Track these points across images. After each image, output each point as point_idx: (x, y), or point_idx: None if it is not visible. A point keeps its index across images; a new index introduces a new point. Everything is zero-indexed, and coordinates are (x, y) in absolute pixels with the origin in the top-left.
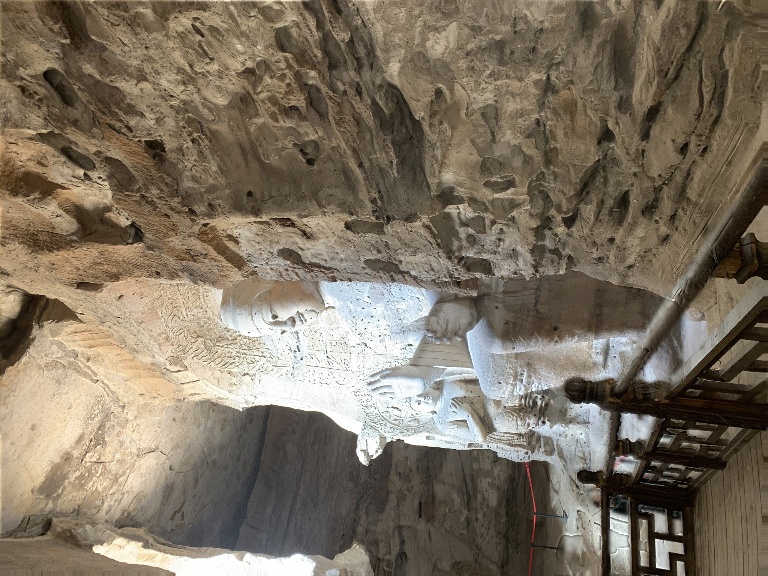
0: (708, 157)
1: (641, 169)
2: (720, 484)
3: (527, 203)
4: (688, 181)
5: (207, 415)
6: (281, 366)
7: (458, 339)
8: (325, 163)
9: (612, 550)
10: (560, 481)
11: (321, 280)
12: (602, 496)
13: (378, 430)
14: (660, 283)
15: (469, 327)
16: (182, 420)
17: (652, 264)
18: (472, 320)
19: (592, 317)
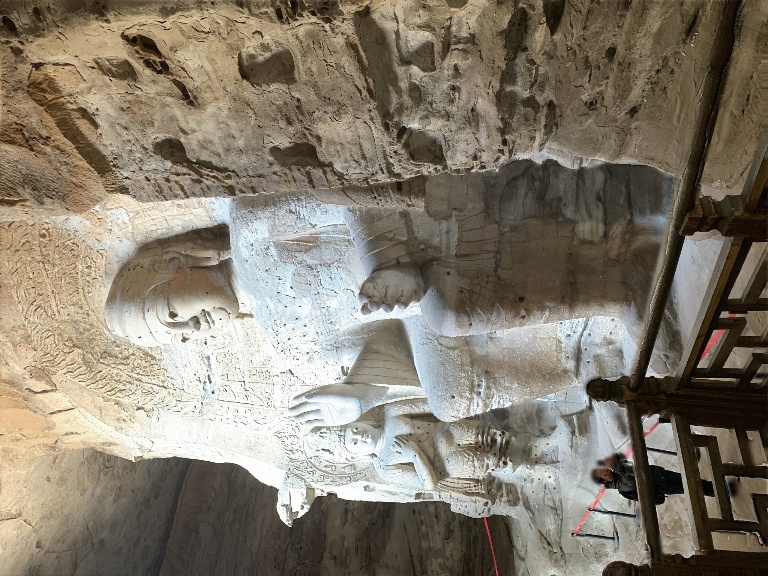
0: None
1: None
2: None
3: None
4: None
5: (96, 479)
6: (187, 401)
7: (400, 307)
8: None
9: (657, 499)
10: (527, 542)
11: (215, 195)
12: (630, 416)
13: (305, 479)
14: (674, 137)
15: (414, 295)
16: (60, 481)
17: (666, 95)
18: (418, 289)
19: (565, 286)
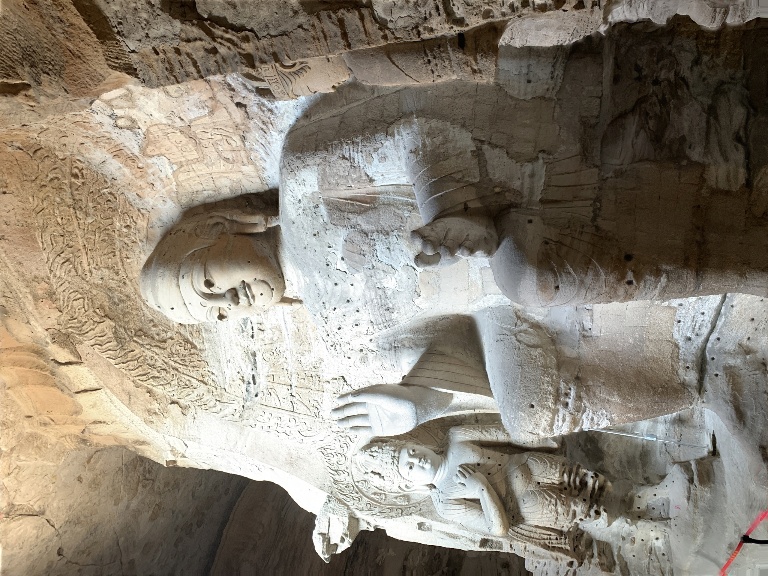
0: None
1: None
2: None
3: None
4: None
5: (133, 490)
6: (227, 402)
7: (464, 252)
8: None
9: None
10: None
11: (232, 71)
12: None
13: (348, 505)
14: None
15: (483, 242)
16: (92, 484)
17: None
18: (489, 238)
19: (690, 245)
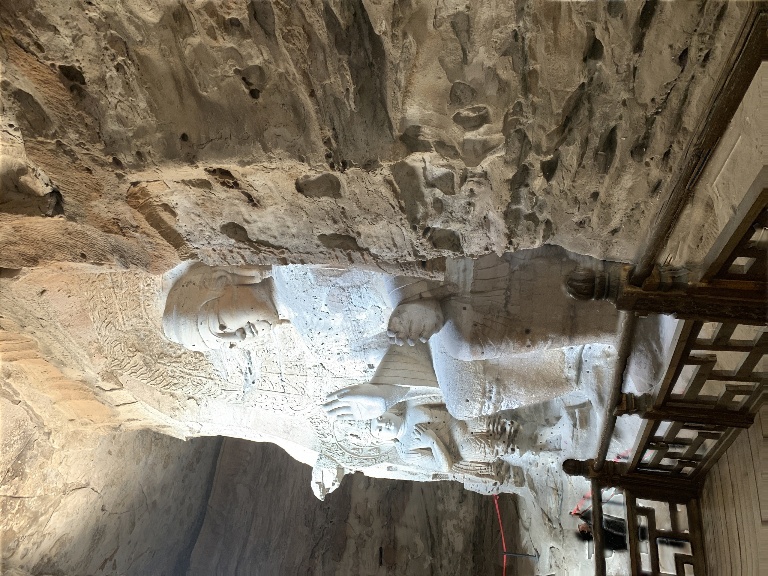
0: (710, 67)
1: (631, 95)
2: (744, 448)
3: (502, 145)
4: (685, 107)
5: (148, 450)
6: (231, 390)
7: (423, 341)
8: (271, 95)
9: (607, 553)
10: (531, 516)
11: (270, 263)
12: (593, 489)
13: (335, 460)
14: None
15: (434, 329)
16: (119, 454)
17: (639, 225)
18: (438, 322)
19: (566, 319)
